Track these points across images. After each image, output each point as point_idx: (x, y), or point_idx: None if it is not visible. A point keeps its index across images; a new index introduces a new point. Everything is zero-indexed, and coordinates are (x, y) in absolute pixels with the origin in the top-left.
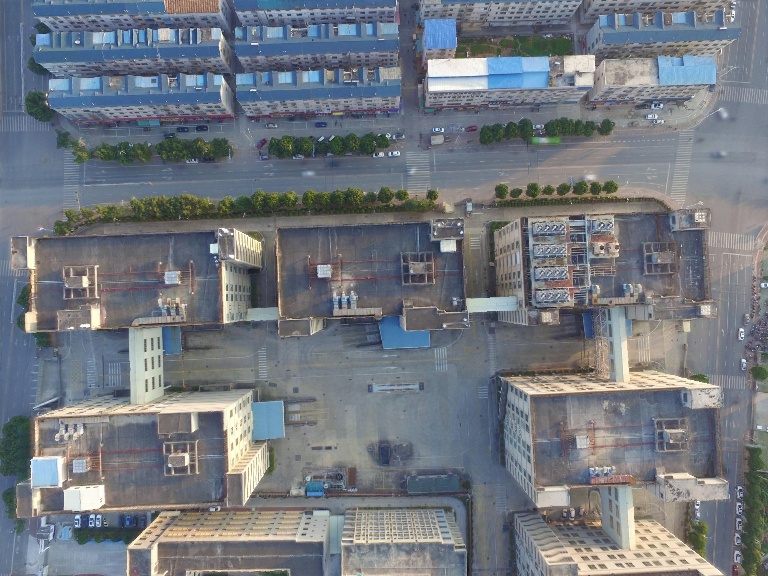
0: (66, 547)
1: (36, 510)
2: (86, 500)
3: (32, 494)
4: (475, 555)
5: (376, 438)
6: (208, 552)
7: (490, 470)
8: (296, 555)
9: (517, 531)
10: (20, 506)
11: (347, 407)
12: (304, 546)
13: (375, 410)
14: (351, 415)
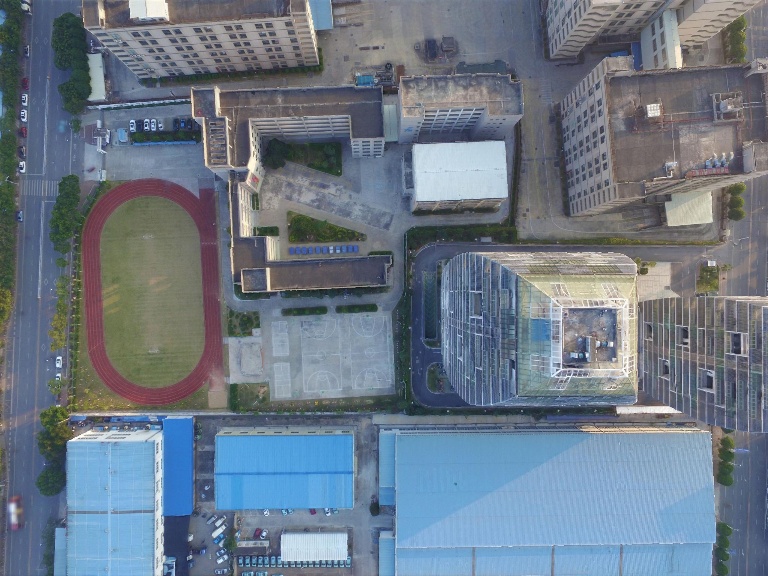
0: (122, 153)
1: (103, 20)
2: (152, 7)
3: (98, 4)
4: (523, 146)
5: (422, 37)
6: (269, 102)
7: (535, 65)
8: (355, 102)
9: (564, 111)
10: (87, 16)
11: (392, 8)
12: (363, 94)
13: (420, 10)
14: (396, 16)
